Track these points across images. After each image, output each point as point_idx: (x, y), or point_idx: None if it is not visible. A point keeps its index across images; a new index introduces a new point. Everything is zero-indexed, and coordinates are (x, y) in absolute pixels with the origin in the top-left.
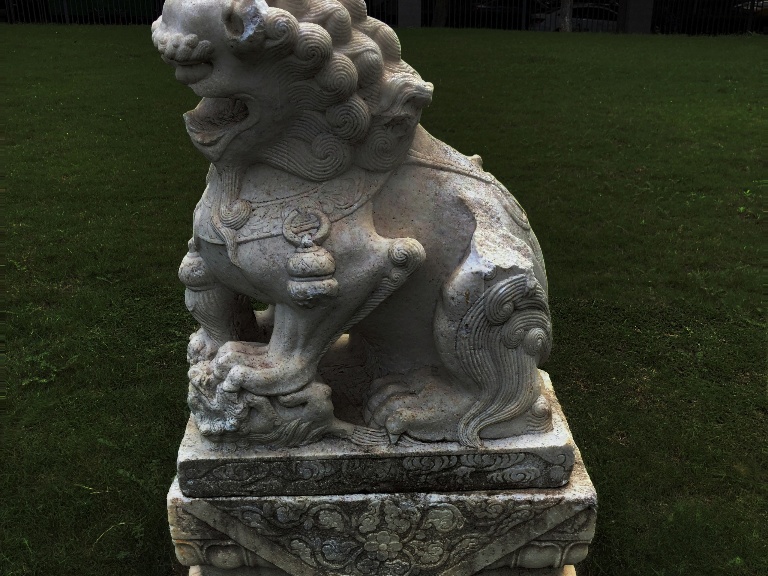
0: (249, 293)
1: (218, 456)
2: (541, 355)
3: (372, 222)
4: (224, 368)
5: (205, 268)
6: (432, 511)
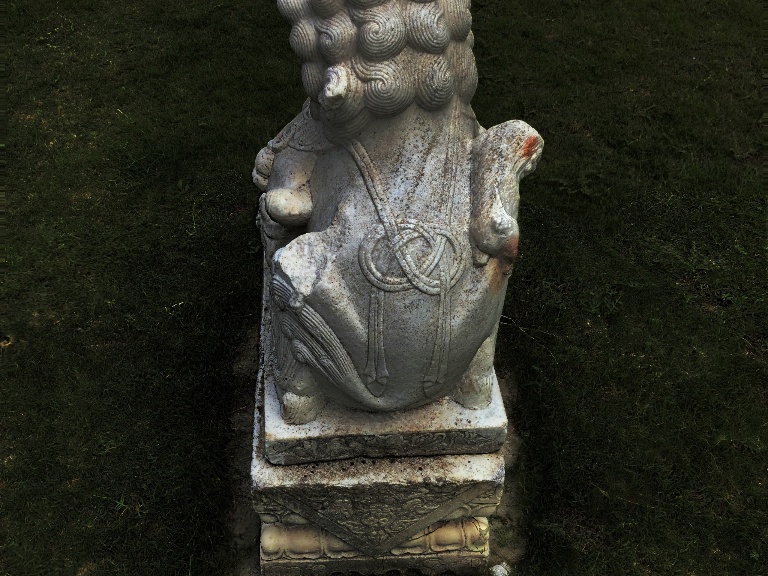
0: None
1: None
2: None
3: (310, 169)
4: None
5: None
6: None
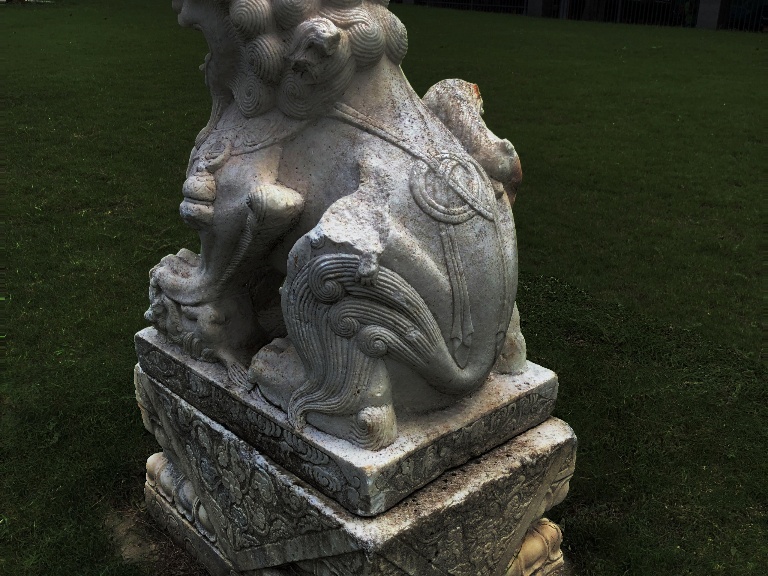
0: None
1: (153, 342)
2: (414, 369)
3: (276, 166)
4: None
5: None
6: (257, 473)
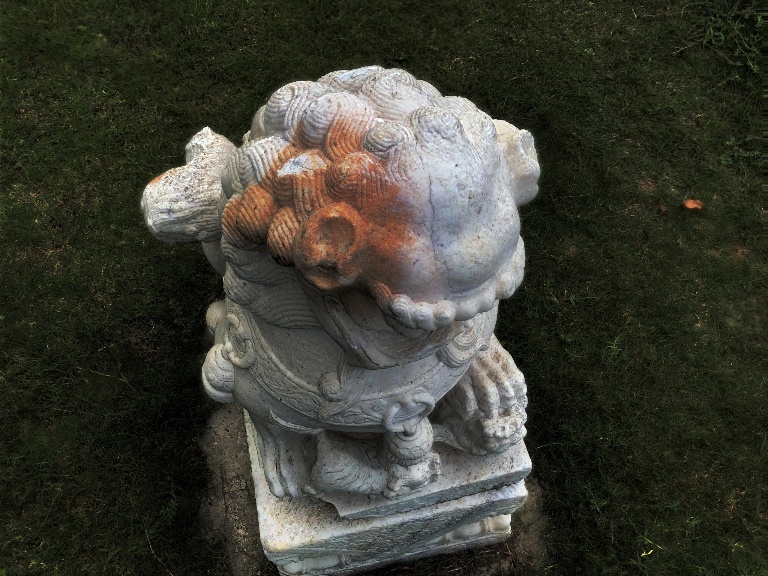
0: None
1: None
2: None
3: None
4: None
5: (426, 417)
6: None
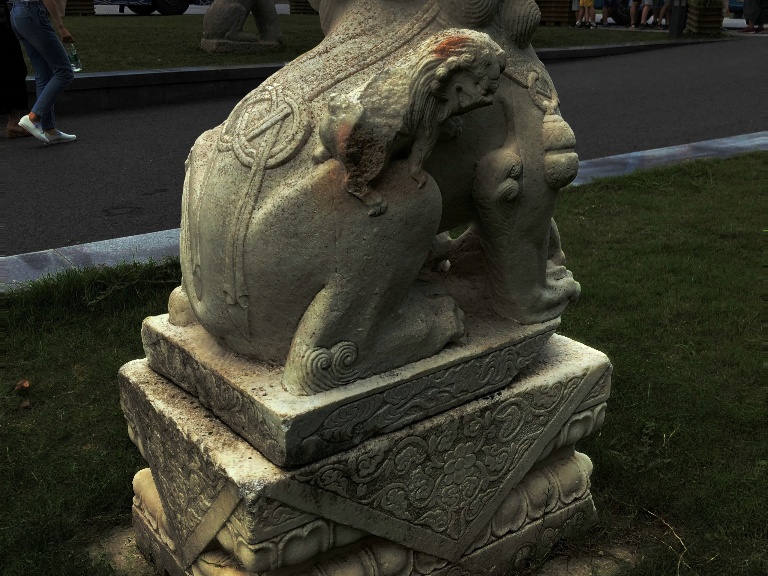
0: None
1: None
2: None
3: None
4: None
5: None
6: None
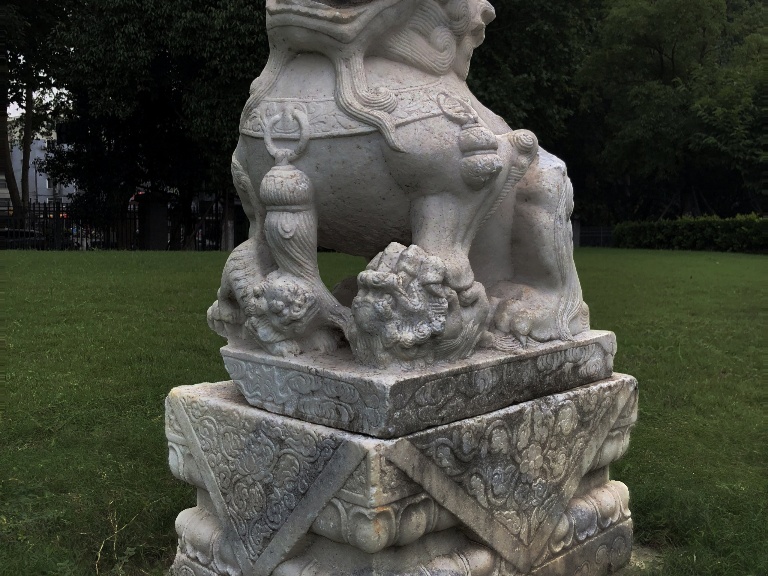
0: (372, 201)
1: (418, 374)
2: None
3: None
4: (416, 261)
5: (308, 181)
6: (561, 411)
